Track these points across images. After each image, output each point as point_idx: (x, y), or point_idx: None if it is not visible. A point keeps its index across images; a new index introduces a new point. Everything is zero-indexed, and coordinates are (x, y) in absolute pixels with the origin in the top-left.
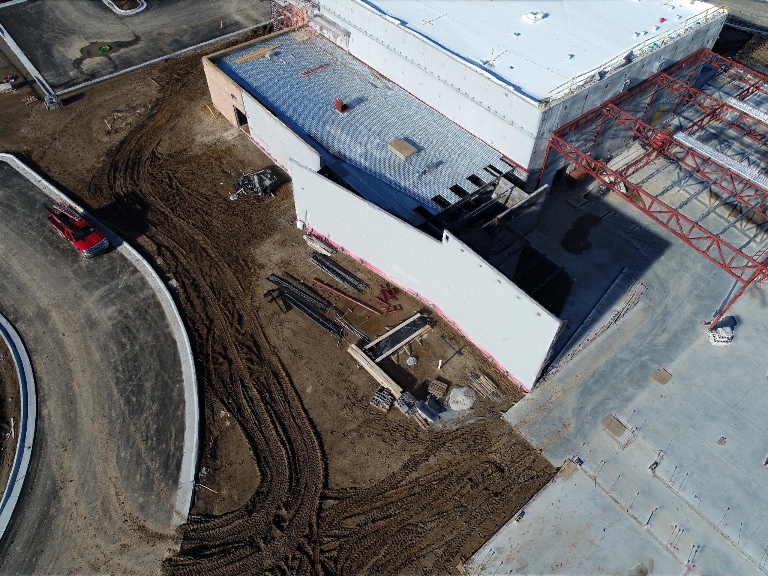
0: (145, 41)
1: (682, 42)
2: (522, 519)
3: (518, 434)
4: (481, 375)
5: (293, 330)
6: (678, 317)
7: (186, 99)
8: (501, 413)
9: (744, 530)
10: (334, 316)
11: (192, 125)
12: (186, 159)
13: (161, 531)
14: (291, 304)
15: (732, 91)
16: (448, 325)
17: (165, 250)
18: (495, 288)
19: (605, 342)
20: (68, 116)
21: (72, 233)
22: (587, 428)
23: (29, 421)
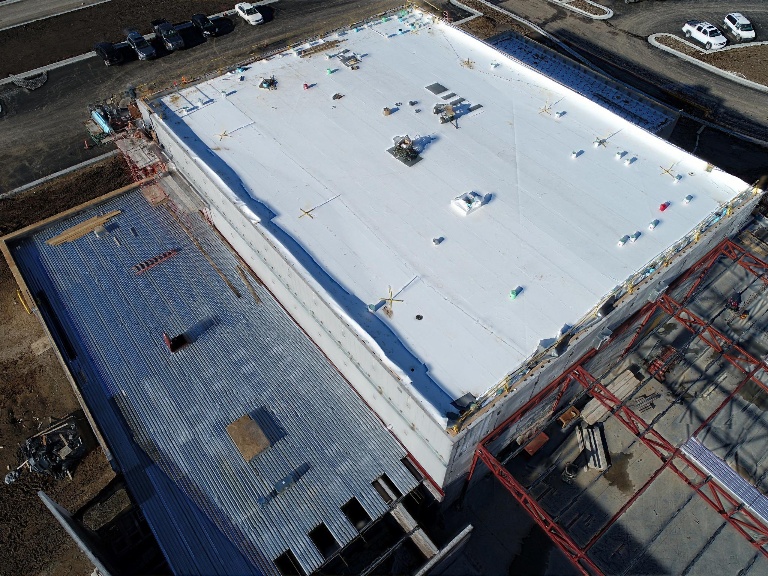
0: None
1: (694, 252)
2: None
3: None
4: None
5: None
6: None
7: None
8: None
9: None
10: None
11: None
12: None
13: None
14: None
15: None
16: None
17: None
18: None
19: None
20: None
21: None
22: None
23: None
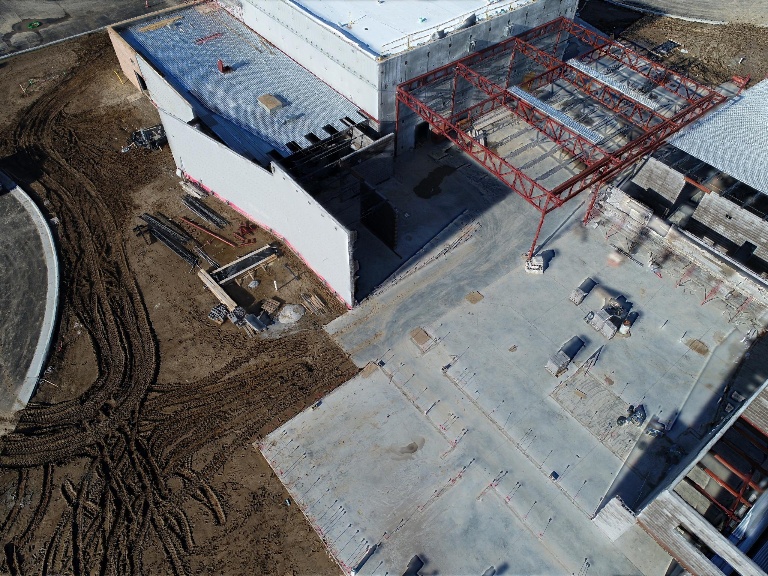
0: (74, 18)
1: (532, 9)
2: (318, 407)
3: (333, 342)
4: (312, 295)
5: (153, 258)
6: (503, 250)
7: (100, 67)
8: (322, 325)
9: (512, 418)
10: (193, 247)
11: (100, 90)
12: (89, 118)
13: (2, 415)
14: (156, 237)
15: (609, 63)
16: (294, 255)
17: (53, 193)
18: (309, 210)
19: (431, 270)
20: None
21: None
22: (395, 337)
23: None
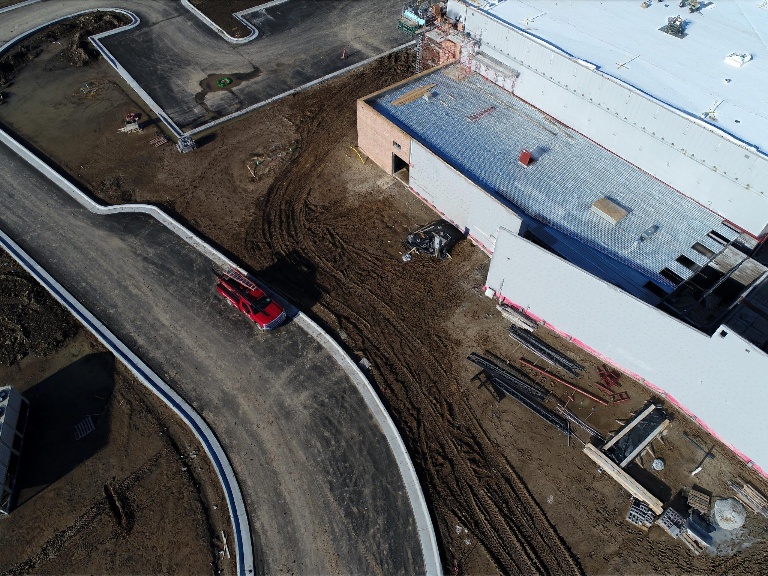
0: (265, 73)
1: None
2: None
3: None
4: (744, 484)
5: (513, 423)
6: None
7: (327, 141)
8: None
9: None
10: (555, 406)
11: (340, 171)
12: (343, 212)
13: None
14: (503, 391)
15: None
16: (687, 419)
17: (346, 322)
18: None
19: None
20: (204, 160)
21: (250, 305)
22: None
23: (243, 537)
